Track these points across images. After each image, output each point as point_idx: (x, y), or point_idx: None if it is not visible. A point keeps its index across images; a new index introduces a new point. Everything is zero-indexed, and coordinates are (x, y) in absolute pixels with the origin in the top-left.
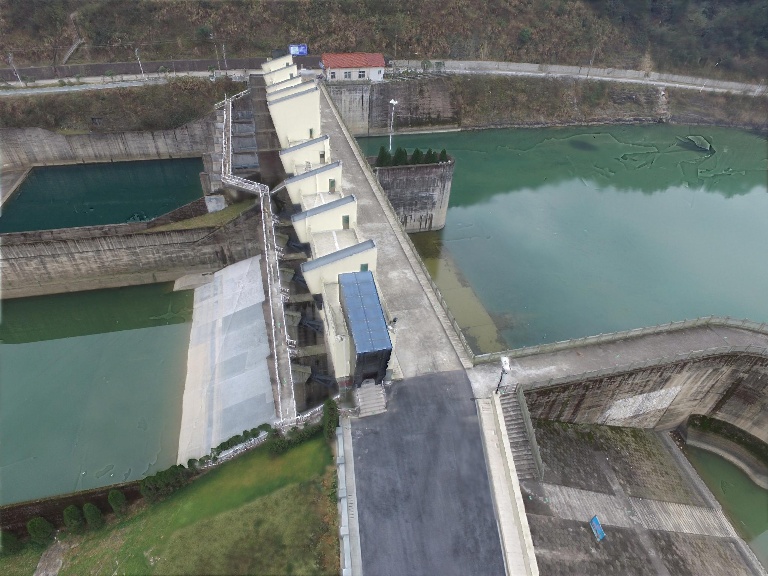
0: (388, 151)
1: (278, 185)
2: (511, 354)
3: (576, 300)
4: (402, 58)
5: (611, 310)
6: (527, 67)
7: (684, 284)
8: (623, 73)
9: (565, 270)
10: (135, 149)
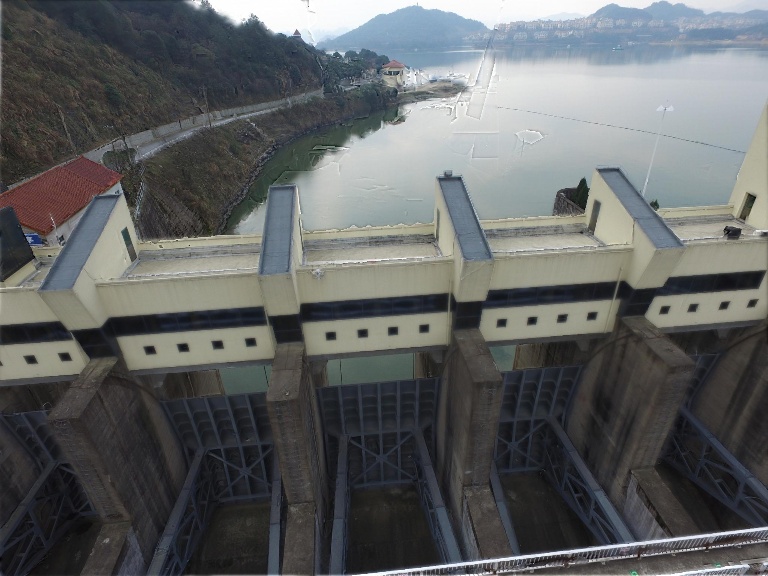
0: (655, 202)
1: None
2: None
3: None
4: (16, 178)
5: None
6: (144, 137)
7: None
8: (201, 119)
9: None
10: None
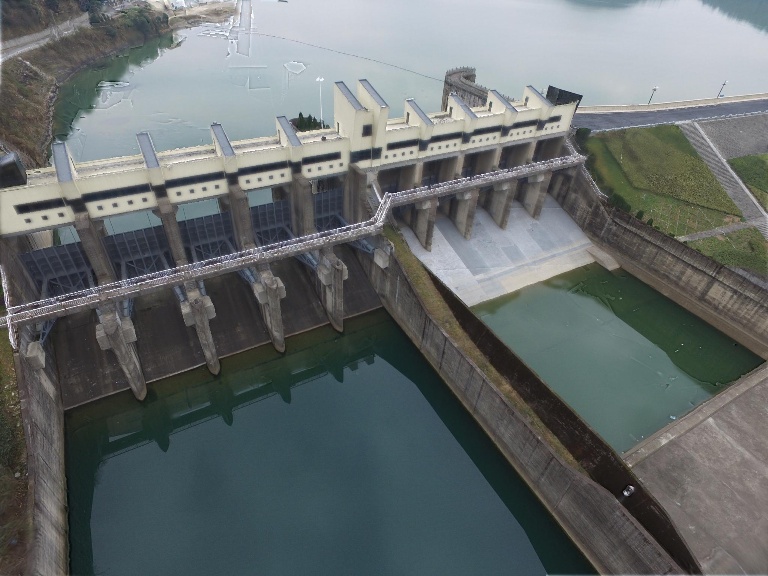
0: None
1: None
2: None
3: None
4: None
5: None
6: None
7: None
8: None
9: None
10: (56, 575)
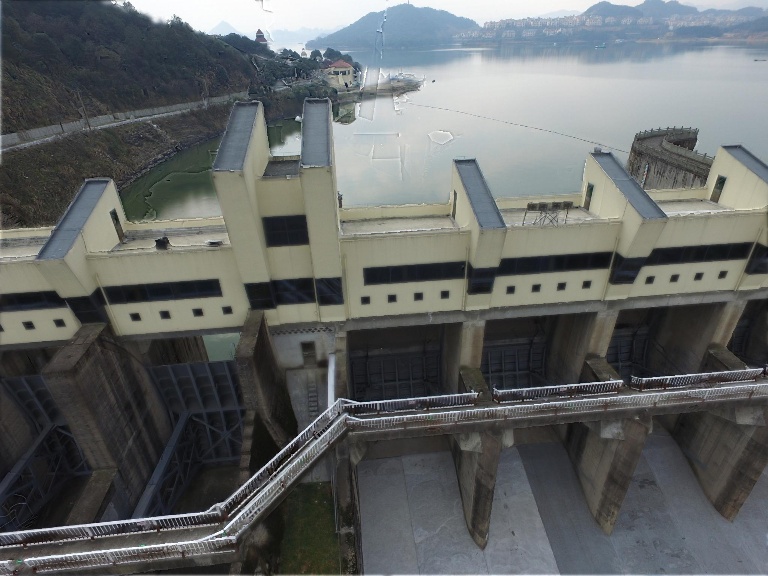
0: None
1: (293, 400)
2: None
3: None
4: None
5: None
6: (5, 140)
7: None
8: (97, 121)
9: None
10: None
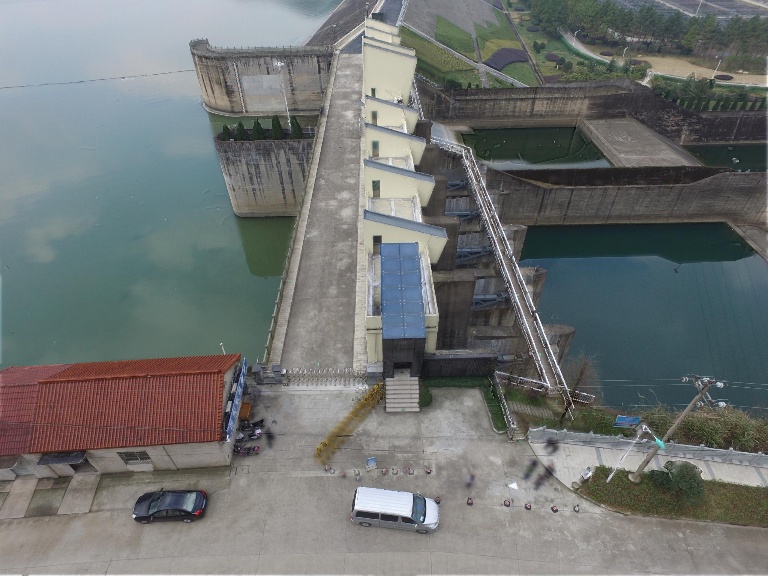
0: None
1: None
2: (318, 53)
3: (202, 153)
4: None
5: (188, 146)
6: None
7: (106, 154)
8: None
9: (177, 169)
10: None
